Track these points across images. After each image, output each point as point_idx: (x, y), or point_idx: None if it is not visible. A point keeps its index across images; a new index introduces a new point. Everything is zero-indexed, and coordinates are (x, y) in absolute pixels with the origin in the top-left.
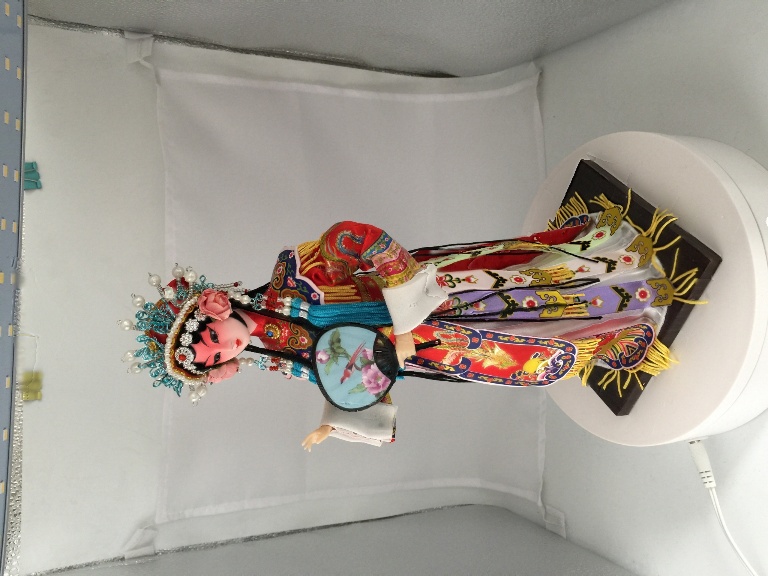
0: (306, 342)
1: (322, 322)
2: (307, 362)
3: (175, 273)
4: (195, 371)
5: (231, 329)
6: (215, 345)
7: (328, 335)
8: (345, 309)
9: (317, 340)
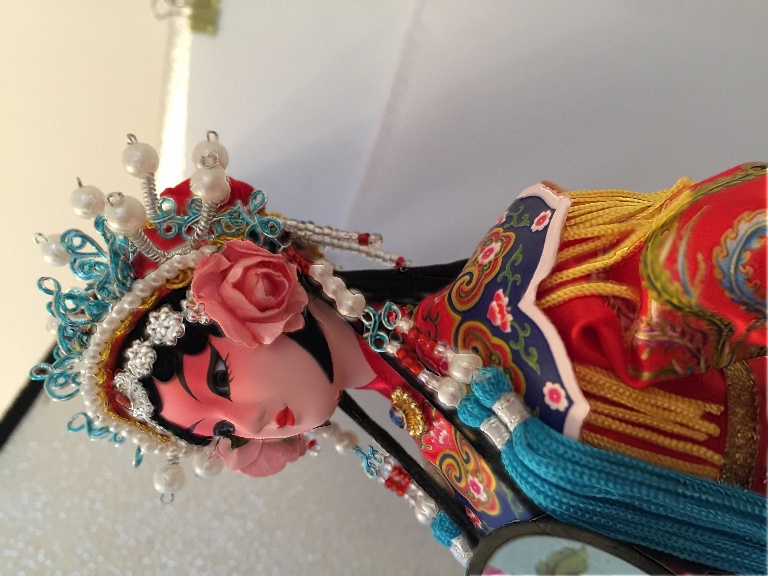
0: (481, 498)
1: (541, 496)
2: (472, 535)
3: (200, 159)
4: None
5: (274, 376)
6: (218, 401)
7: (544, 545)
8: (644, 492)
9: (502, 537)
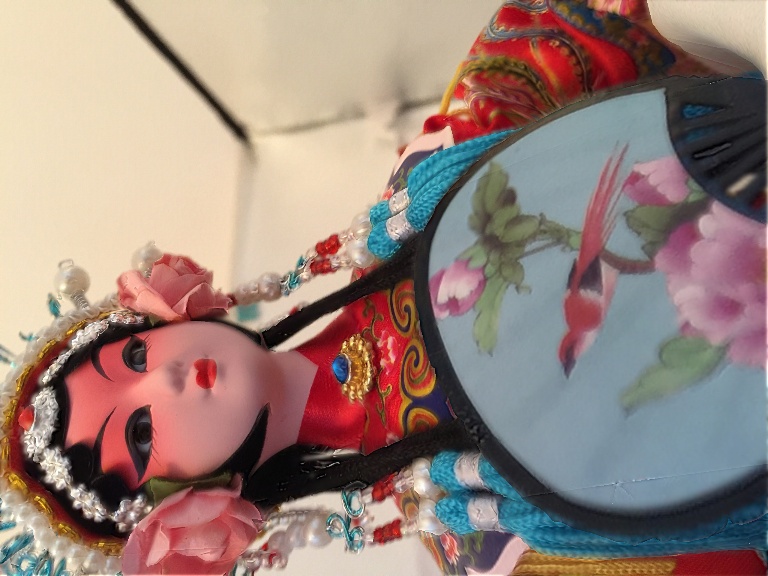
0: None
1: (442, 183)
2: None
3: None
4: (79, 495)
5: (193, 331)
6: (133, 377)
7: (463, 201)
8: None
9: (427, 238)
